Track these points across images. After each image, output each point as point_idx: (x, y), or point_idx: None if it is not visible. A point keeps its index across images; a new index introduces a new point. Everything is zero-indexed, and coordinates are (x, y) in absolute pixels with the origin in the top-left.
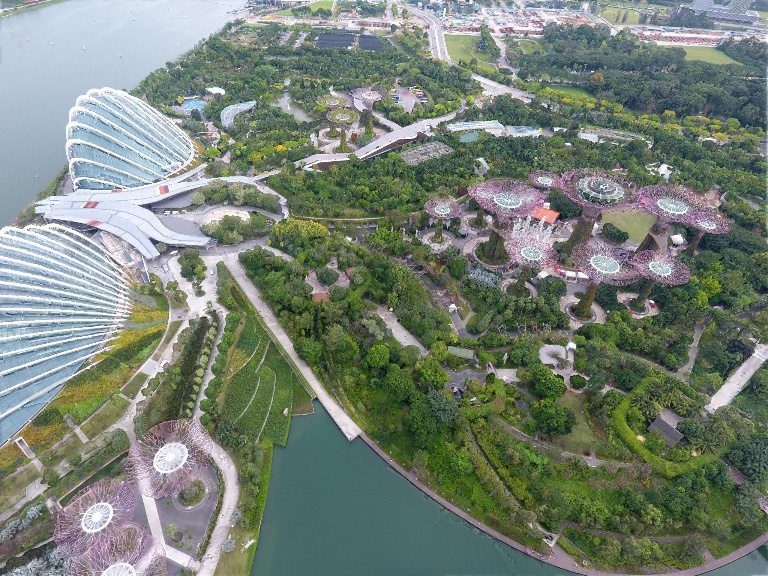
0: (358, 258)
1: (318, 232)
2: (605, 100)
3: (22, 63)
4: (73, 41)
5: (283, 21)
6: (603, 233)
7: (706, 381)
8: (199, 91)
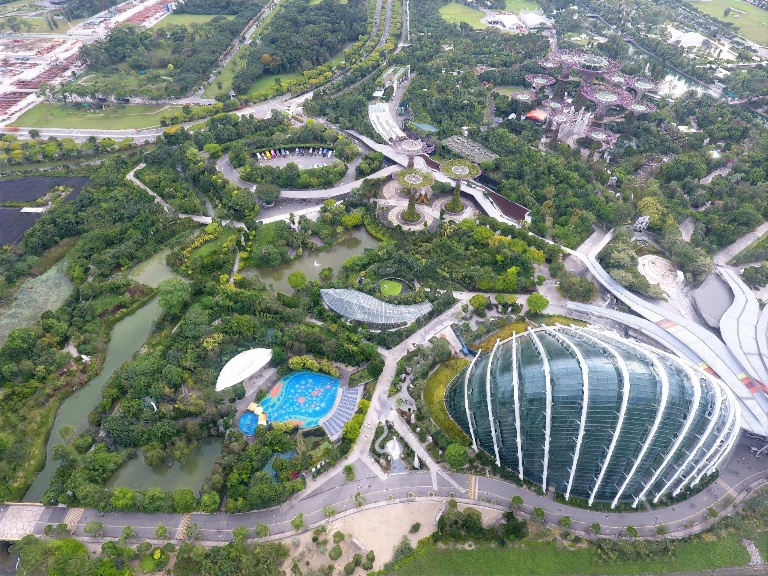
0: (659, 188)
1: None
2: (309, 68)
3: None
4: None
5: None
6: (536, 105)
7: (663, 100)
8: (242, 396)
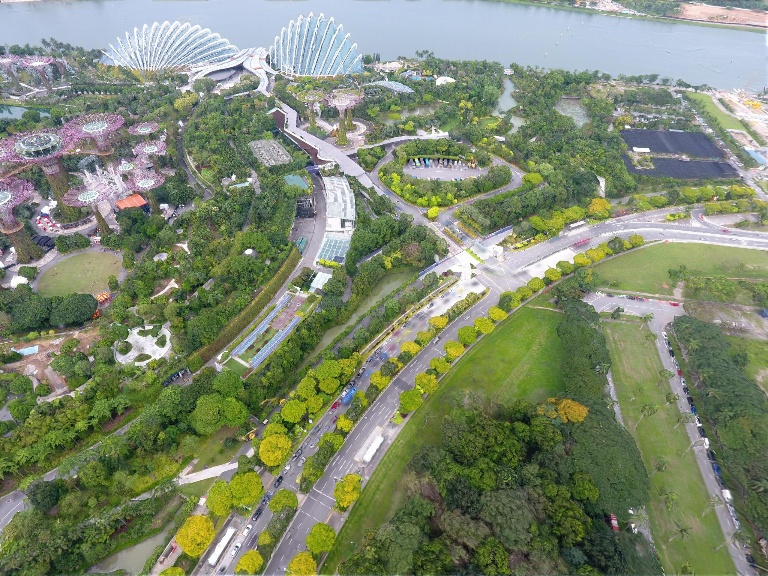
0: None
1: (175, 103)
2: None
3: (512, 34)
4: (577, 40)
5: (748, 113)
6: None
7: None
8: None
